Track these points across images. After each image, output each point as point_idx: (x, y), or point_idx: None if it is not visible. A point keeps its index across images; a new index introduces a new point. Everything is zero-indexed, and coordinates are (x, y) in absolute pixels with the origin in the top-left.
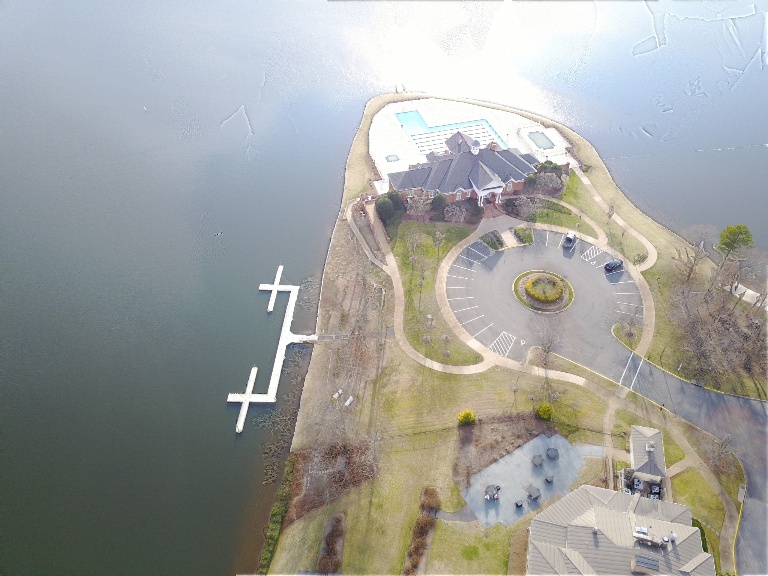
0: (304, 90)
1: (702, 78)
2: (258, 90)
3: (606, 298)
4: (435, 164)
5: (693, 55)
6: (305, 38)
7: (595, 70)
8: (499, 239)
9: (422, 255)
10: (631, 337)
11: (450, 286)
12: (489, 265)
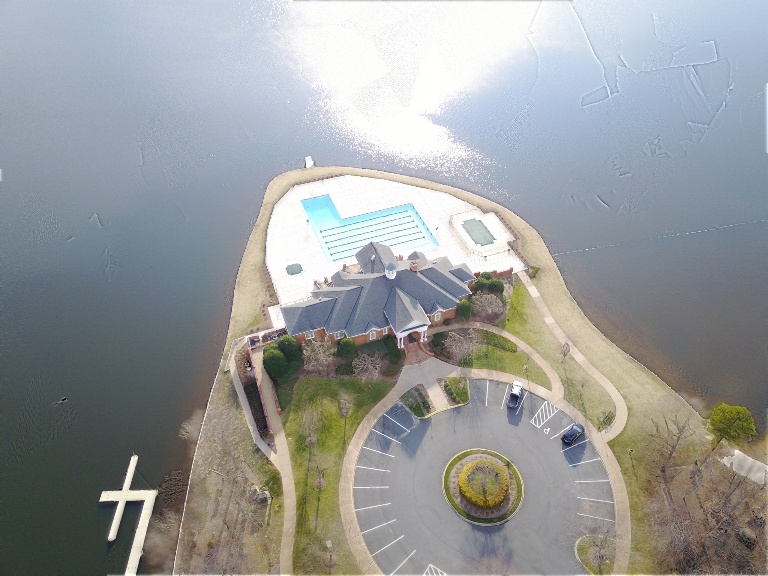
0: (193, 168)
1: (662, 136)
2: (137, 169)
3: (565, 492)
4: (340, 294)
5: (651, 111)
6: (190, 104)
7: (540, 127)
8: (425, 400)
9: (323, 434)
10: (601, 562)
11: (359, 486)
12: (411, 444)
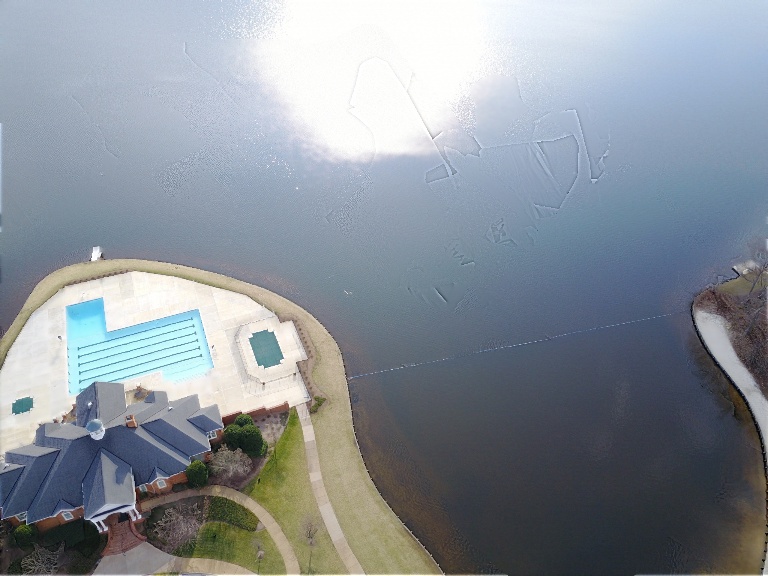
0: None
1: (506, 221)
2: None
3: None
4: (29, 462)
5: (490, 194)
6: None
7: (376, 208)
8: None
9: None
10: None
11: None
12: None
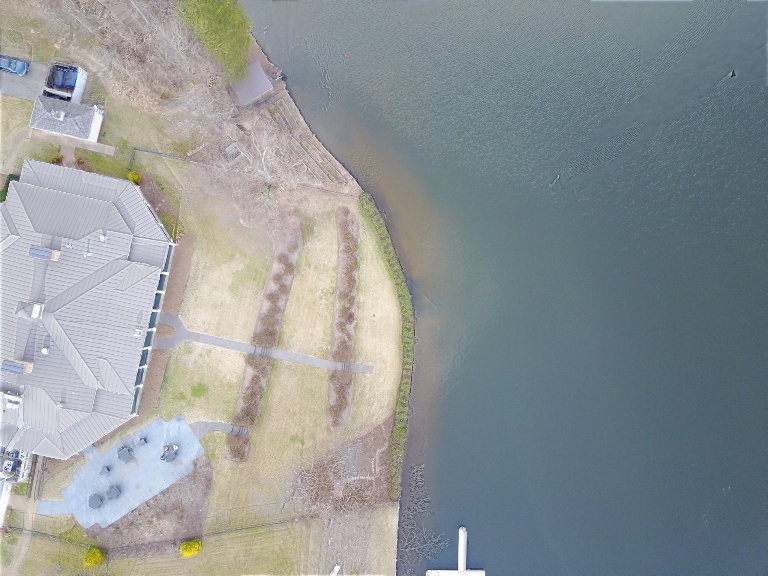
0: None
1: None
2: None
3: None
4: None
5: None
6: None
7: None
8: None
9: None
10: None
11: None
12: None
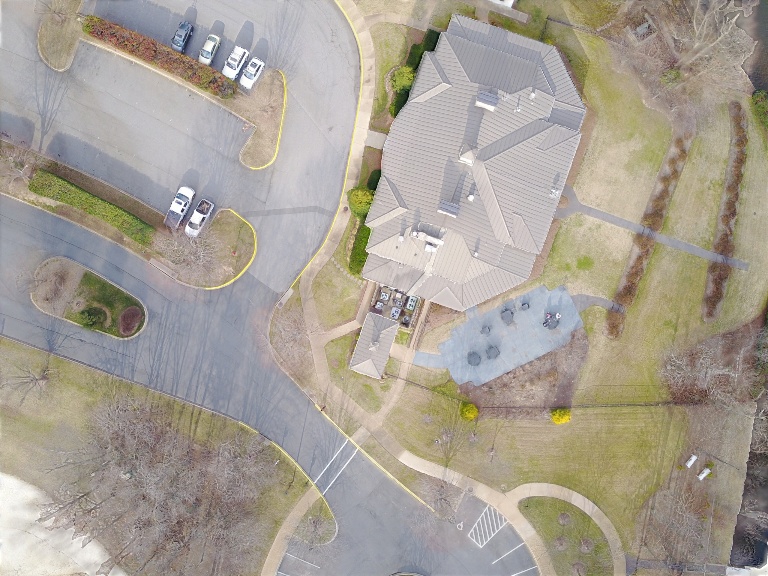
0: None
1: None
2: None
3: None
4: None
5: None
6: None
7: None
8: None
9: None
10: (317, 519)
11: None
12: None
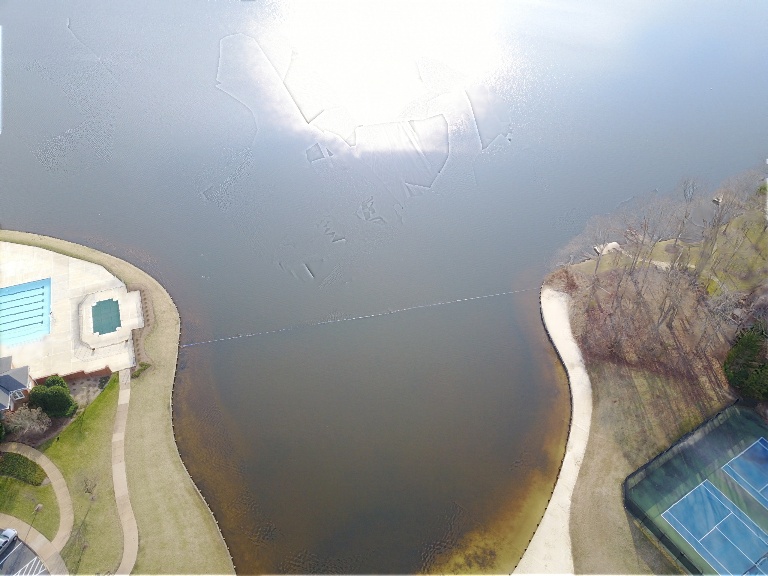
0: None
1: (375, 199)
2: None
3: None
4: None
5: (357, 171)
6: None
7: (254, 184)
8: None
9: None
10: None
11: None
12: None
